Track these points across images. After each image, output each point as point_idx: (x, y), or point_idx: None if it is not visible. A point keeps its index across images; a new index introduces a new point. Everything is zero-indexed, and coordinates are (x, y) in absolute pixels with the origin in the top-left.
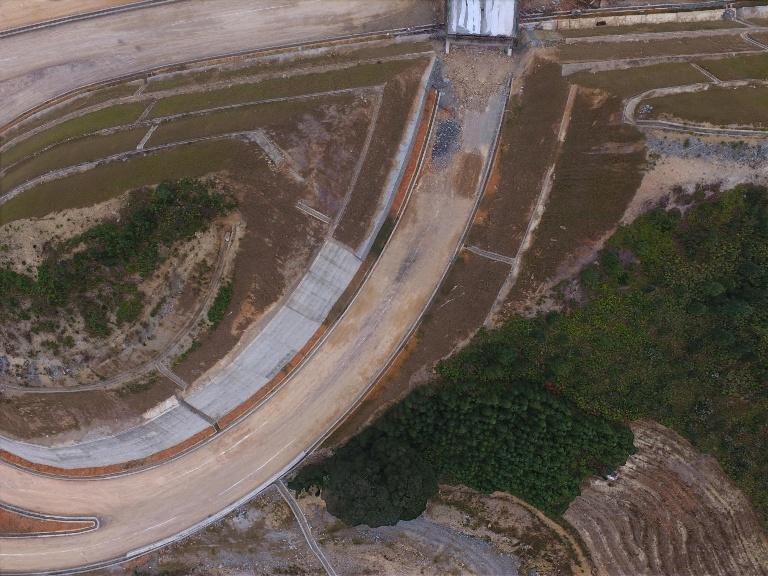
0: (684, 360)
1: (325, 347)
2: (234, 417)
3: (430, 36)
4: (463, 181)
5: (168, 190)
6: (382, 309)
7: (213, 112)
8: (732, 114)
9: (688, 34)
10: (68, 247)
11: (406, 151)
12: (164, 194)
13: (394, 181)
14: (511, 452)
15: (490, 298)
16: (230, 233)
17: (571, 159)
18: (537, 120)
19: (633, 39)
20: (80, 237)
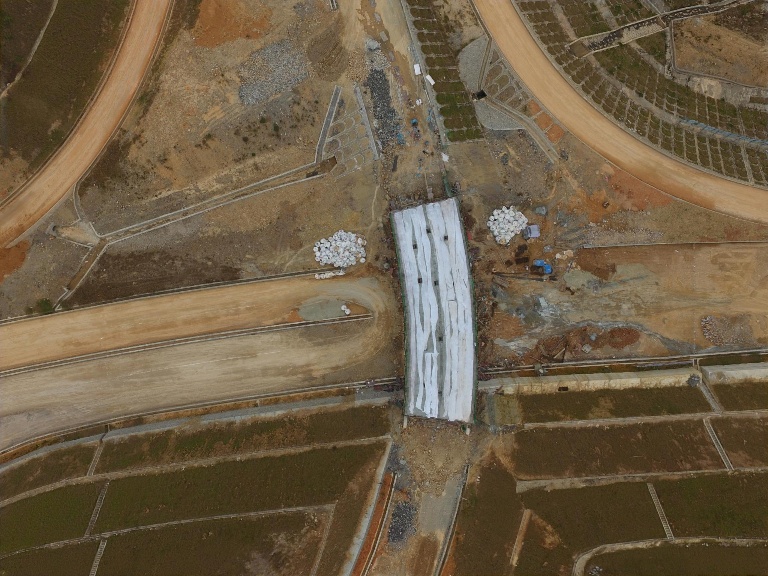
0: None
1: None
2: None
3: (389, 400)
4: (418, 567)
5: None
6: None
7: (162, 527)
8: None
9: (649, 419)
10: None
11: (360, 544)
12: None
13: (347, 573)
14: None
15: None
16: None
17: None
18: (491, 527)
19: (593, 424)
20: None
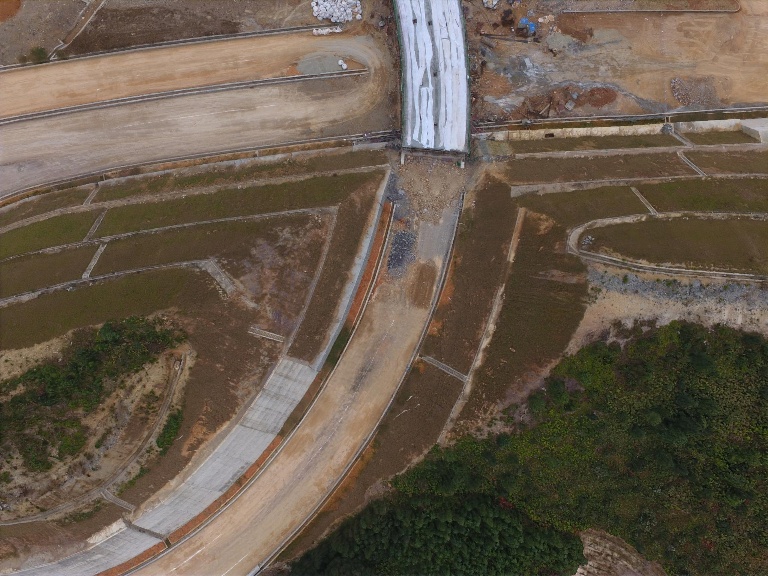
0: (628, 477)
1: (280, 457)
2: (186, 532)
3: (386, 145)
4: (418, 292)
5: (113, 332)
6: (338, 418)
7: (165, 231)
8: (666, 251)
9: (629, 151)
10: (5, 389)
11: (361, 264)
12: (108, 337)
13: (349, 294)
14: (466, 564)
15: (443, 415)
16: (180, 362)
17: (520, 281)
18: (488, 237)
19: (579, 155)
20: (18, 379)
